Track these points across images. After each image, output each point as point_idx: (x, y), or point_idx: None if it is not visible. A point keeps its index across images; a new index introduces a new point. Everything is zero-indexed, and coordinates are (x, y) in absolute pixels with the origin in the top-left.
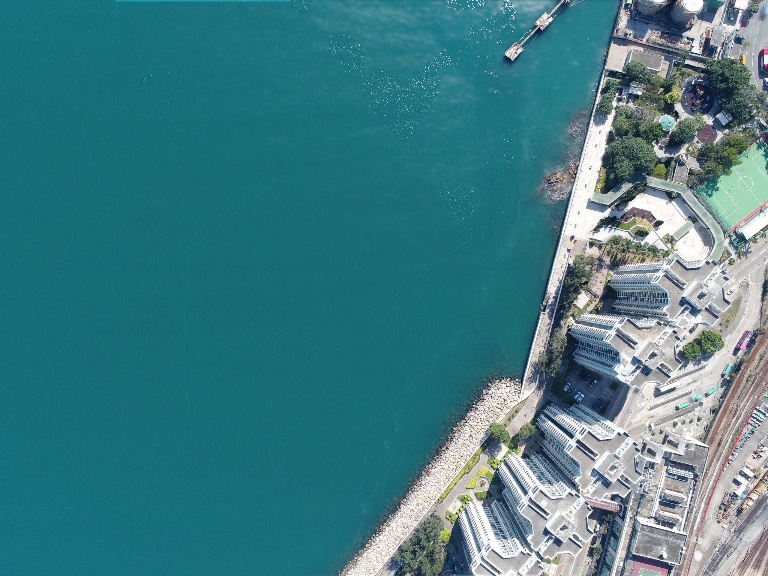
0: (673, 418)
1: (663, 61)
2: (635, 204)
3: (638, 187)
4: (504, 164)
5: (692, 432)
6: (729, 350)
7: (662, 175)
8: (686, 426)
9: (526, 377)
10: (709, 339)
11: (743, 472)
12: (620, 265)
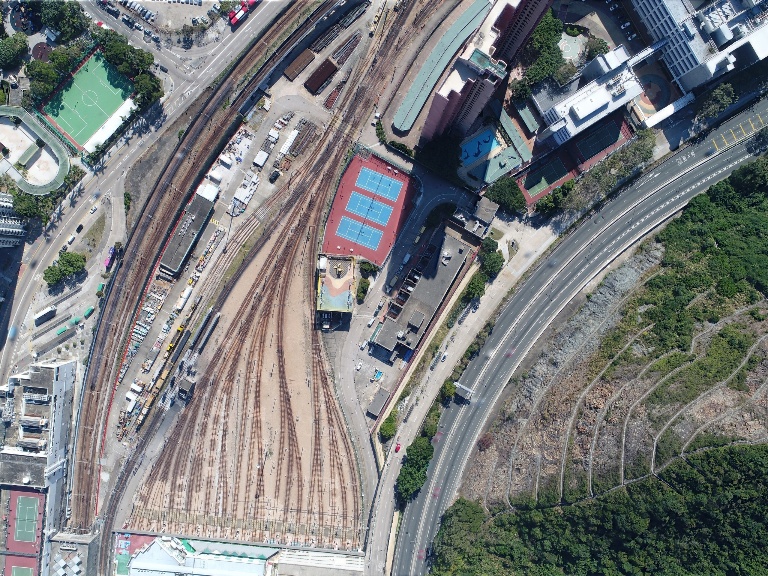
0: (56, 345)
1: None
2: None
3: None
4: None
5: (78, 356)
6: (102, 269)
7: (2, 101)
8: (71, 351)
9: None
10: (65, 260)
11: (132, 388)
12: None
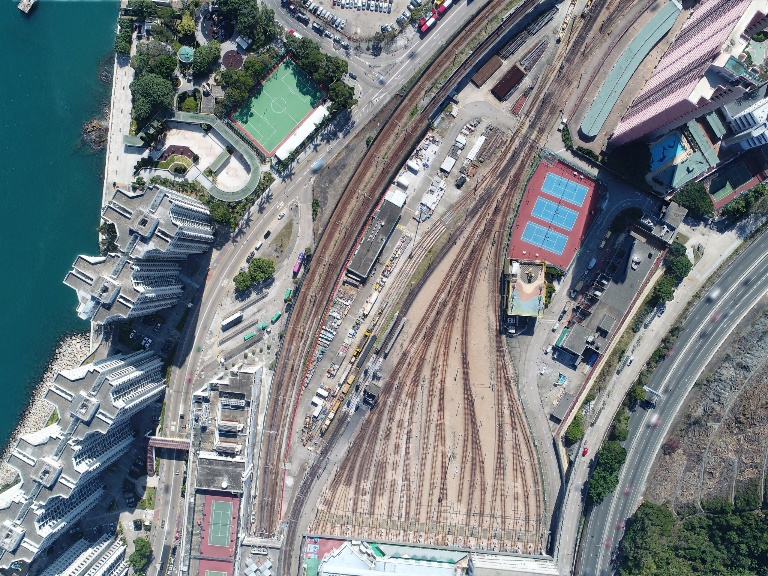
0: (243, 350)
1: None
2: (172, 142)
3: (172, 124)
4: (7, 119)
5: (264, 361)
6: (288, 274)
7: (193, 108)
8: (257, 356)
9: (93, 330)
10: (257, 266)
11: (318, 393)
12: None
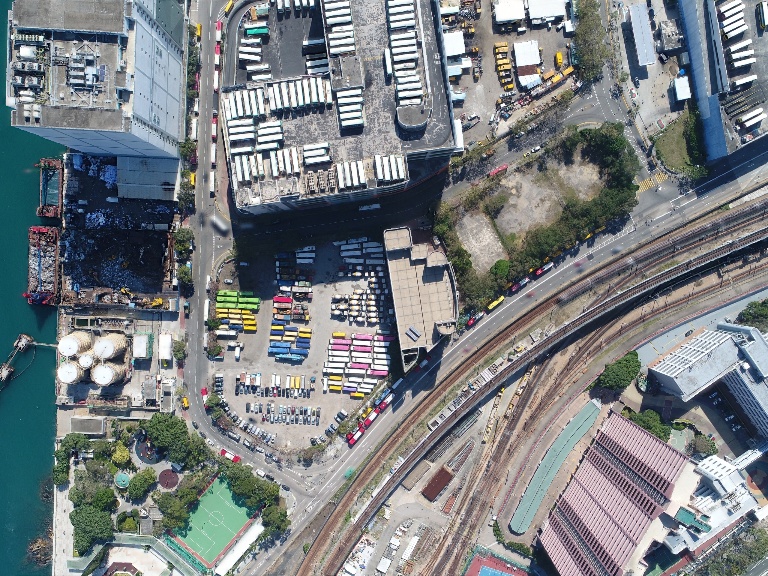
0: None
1: (110, 417)
2: (115, 559)
3: None
4: None
5: None
6: None
7: (133, 528)
8: None
9: None
10: None
11: None
12: None
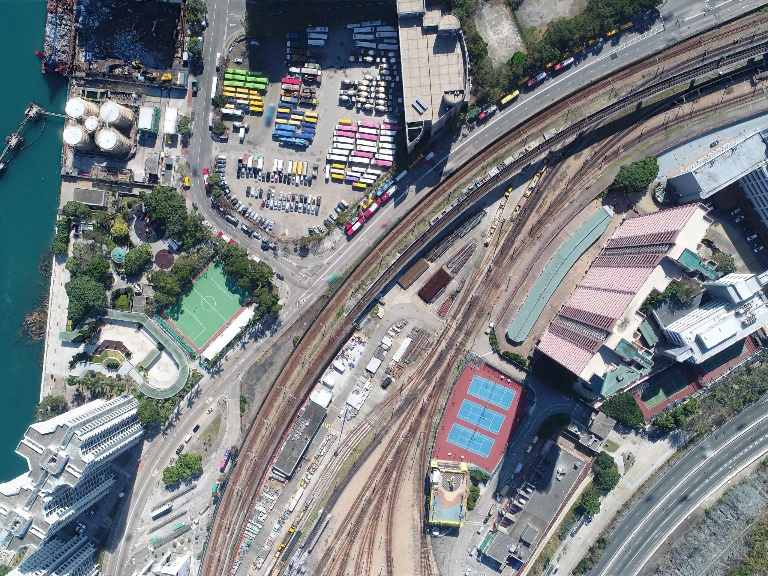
0: (172, 539)
1: None
2: (106, 336)
3: (107, 319)
4: None
5: (192, 550)
6: (216, 468)
7: (126, 305)
8: (186, 545)
9: None
10: (184, 463)
11: None
12: (99, 398)
